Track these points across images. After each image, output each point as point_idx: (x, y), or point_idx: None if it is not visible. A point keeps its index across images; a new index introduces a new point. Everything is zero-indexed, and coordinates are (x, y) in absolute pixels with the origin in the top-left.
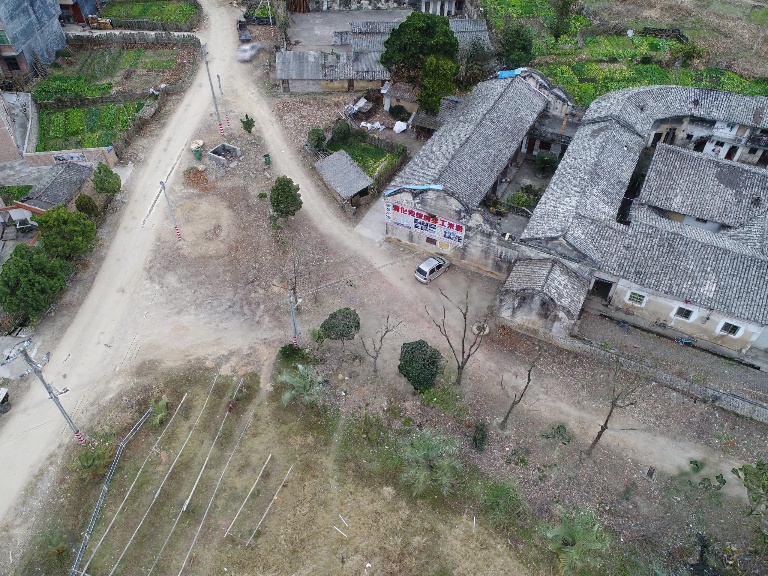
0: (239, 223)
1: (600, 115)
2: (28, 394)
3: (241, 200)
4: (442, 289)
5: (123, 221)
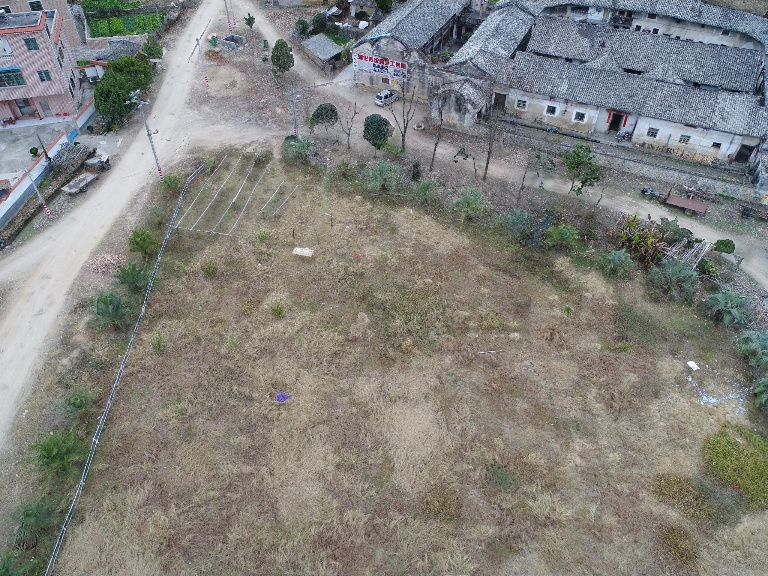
0: (249, 80)
1: (505, 3)
2: (120, 162)
3: (249, 67)
4: (393, 109)
5: (165, 79)
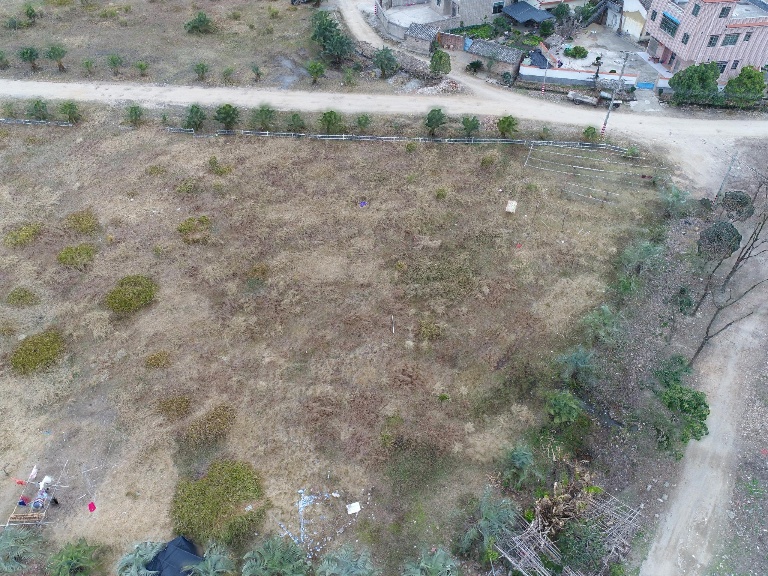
0: None
1: None
2: (624, 114)
3: None
4: None
5: None
